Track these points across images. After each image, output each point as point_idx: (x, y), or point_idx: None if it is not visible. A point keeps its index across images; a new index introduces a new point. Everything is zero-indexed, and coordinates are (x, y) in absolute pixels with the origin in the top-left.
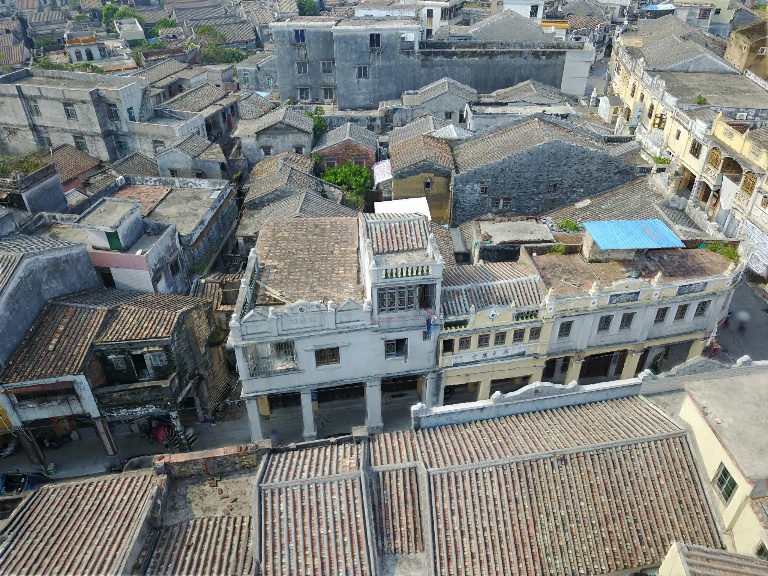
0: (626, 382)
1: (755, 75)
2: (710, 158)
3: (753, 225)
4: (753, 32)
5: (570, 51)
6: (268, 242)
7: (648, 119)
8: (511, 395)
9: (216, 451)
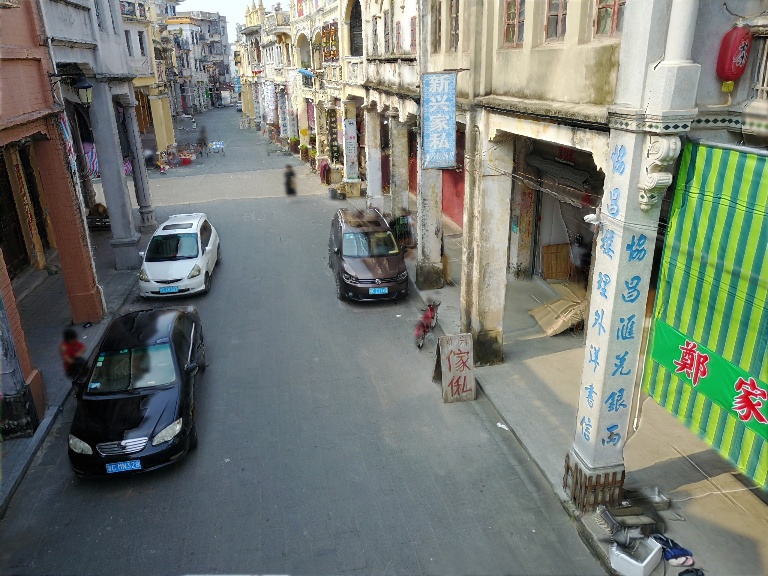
0: None
1: None
2: (253, 56)
3: (267, 83)
4: None
5: None
6: None
7: None
8: None
9: None
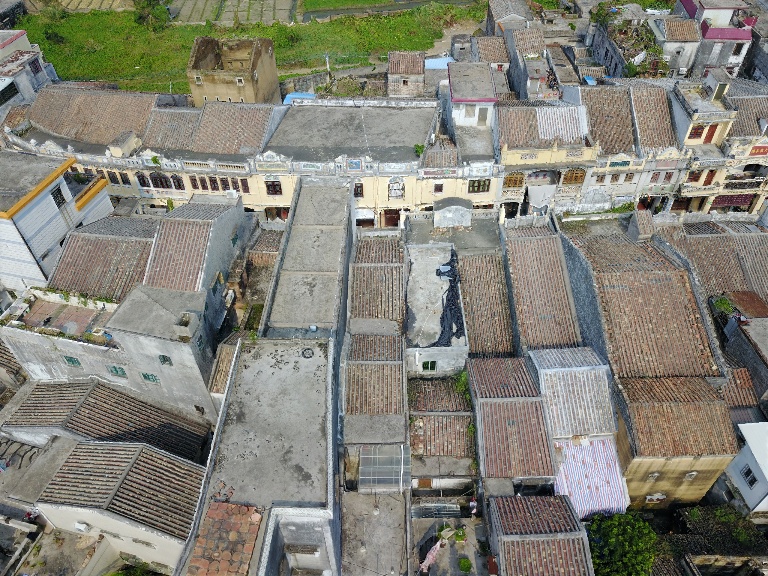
0: None
1: (314, 100)
2: (504, 183)
3: None
4: (198, 62)
5: (351, 197)
6: None
7: (357, 199)
8: None
9: None
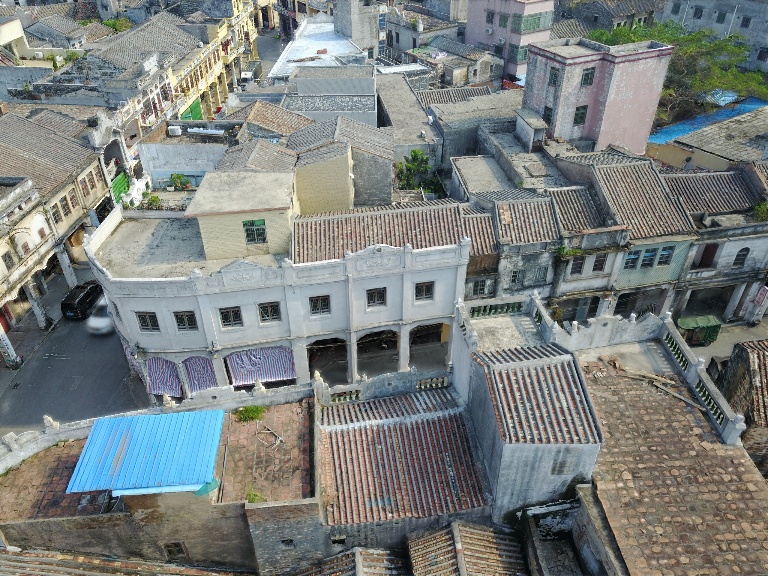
0: (304, 263)
1: None
2: None
3: None
4: None
5: None
6: (763, 504)
7: None
8: (398, 247)
9: (595, 231)
